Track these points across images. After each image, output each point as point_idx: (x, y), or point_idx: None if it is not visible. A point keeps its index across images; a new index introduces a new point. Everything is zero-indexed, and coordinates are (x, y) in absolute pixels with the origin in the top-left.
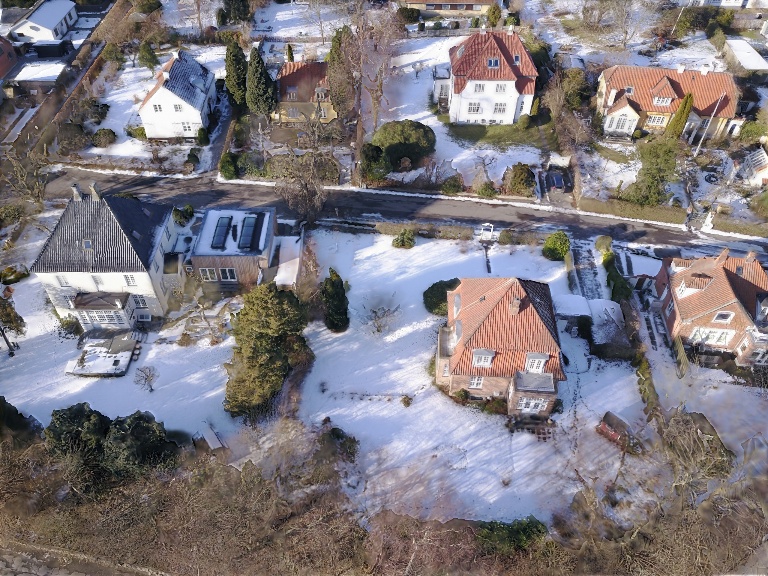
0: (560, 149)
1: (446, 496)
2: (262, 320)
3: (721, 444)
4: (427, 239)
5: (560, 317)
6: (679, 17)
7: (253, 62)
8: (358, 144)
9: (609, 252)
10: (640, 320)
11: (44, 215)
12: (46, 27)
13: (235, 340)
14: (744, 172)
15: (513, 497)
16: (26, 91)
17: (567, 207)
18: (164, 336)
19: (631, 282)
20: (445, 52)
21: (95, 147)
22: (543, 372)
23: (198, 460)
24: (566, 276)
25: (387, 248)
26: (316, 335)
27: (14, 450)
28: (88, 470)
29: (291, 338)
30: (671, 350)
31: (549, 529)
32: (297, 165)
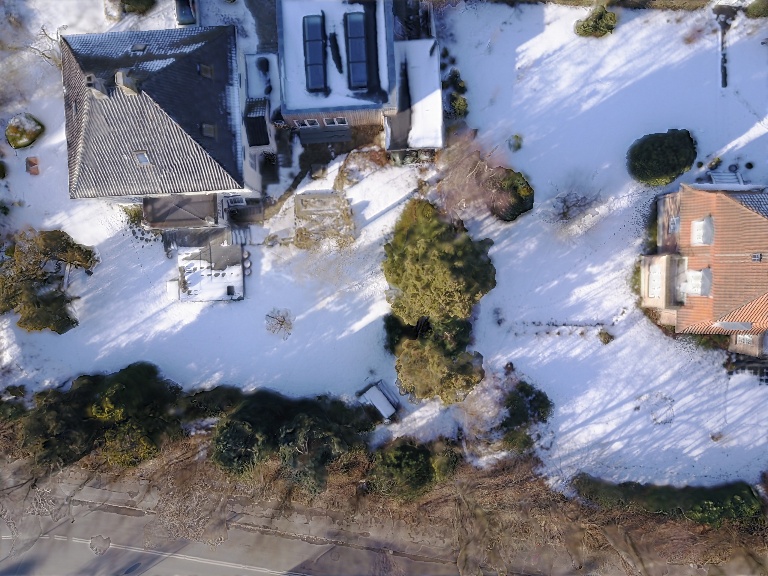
0: None
1: (647, 455)
2: None
3: None
4: (630, 11)
5: None
6: None
7: None
8: None
9: None
10: None
11: None
12: None
13: None
14: None
15: (720, 453)
16: None
17: None
18: (272, 230)
19: None
20: None
21: None
22: None
23: (371, 425)
24: None
25: (566, 37)
26: (477, 226)
27: (170, 437)
28: None
29: None
30: None
31: (754, 487)
32: None
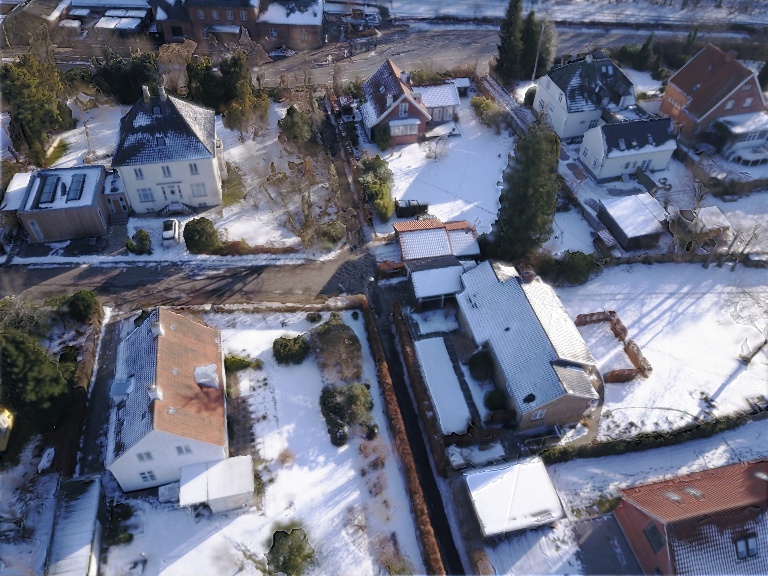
0: None
1: None
2: None
3: None
4: None
5: None
6: None
7: None
8: None
9: None
10: None
11: (298, 239)
12: None
13: None
14: None
15: None
16: None
17: None
18: None
19: None
20: None
21: None
22: None
23: None
24: None
25: None
26: None
27: None
28: None
29: None
30: None
31: None
32: None
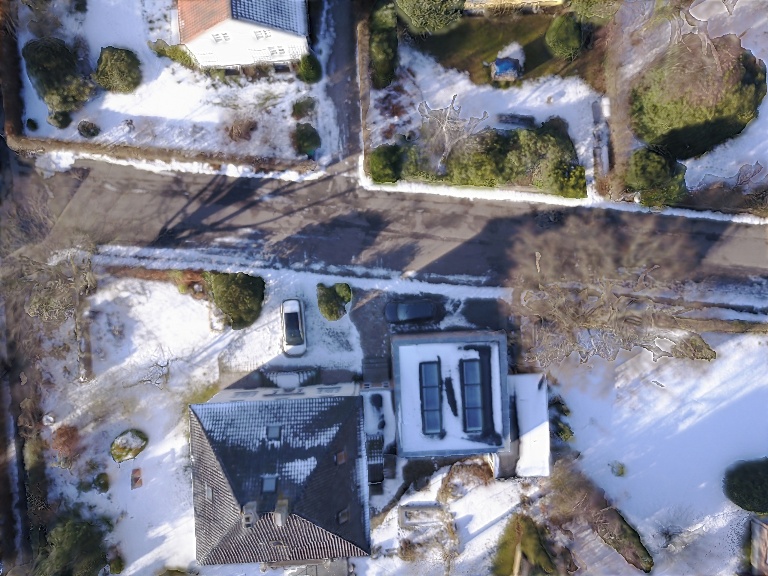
0: None
1: None
2: None
3: None
4: (724, 334)
5: None
6: None
7: None
8: (616, 100)
9: None
10: None
11: (104, 296)
12: None
13: None
14: None
15: None
16: None
17: None
18: (376, 541)
19: None
20: None
21: (109, 92)
22: None
23: None
24: None
25: (663, 358)
26: (579, 543)
27: None
28: None
29: None
30: None
31: None
32: None
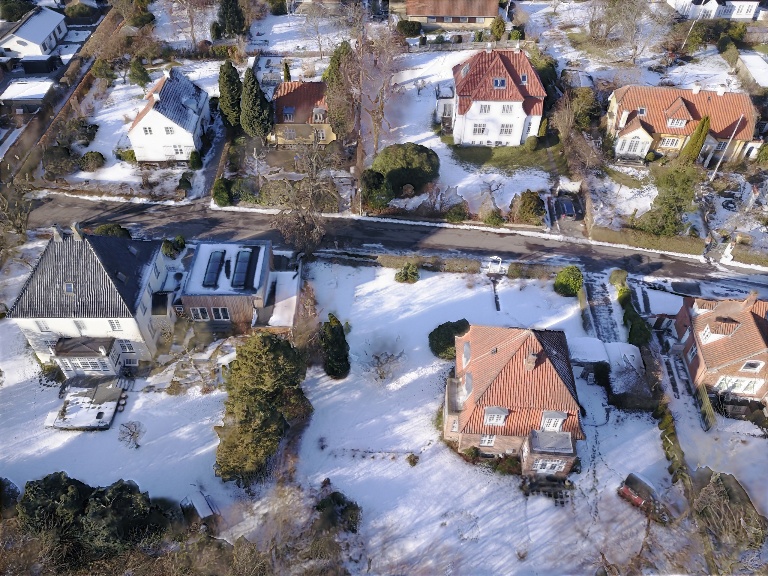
0: (570, 173)
1: (457, 571)
2: (256, 376)
3: (755, 512)
4: (432, 272)
5: (576, 363)
6: (690, 31)
7: (248, 83)
8: (358, 168)
9: (625, 287)
10: (663, 369)
11: (27, 247)
12: (34, 42)
13: (227, 392)
14: (763, 198)
15: (530, 572)
16: (12, 110)
17: (578, 236)
18: (152, 383)
19: (649, 322)
20: (448, 68)
21: (82, 171)
22: (560, 431)
23: (187, 530)
24: (580, 314)
25: (389, 283)
26: (315, 382)
27: None
28: (67, 542)
29: (288, 391)
30: (694, 398)
31: None
32: (294, 198)
